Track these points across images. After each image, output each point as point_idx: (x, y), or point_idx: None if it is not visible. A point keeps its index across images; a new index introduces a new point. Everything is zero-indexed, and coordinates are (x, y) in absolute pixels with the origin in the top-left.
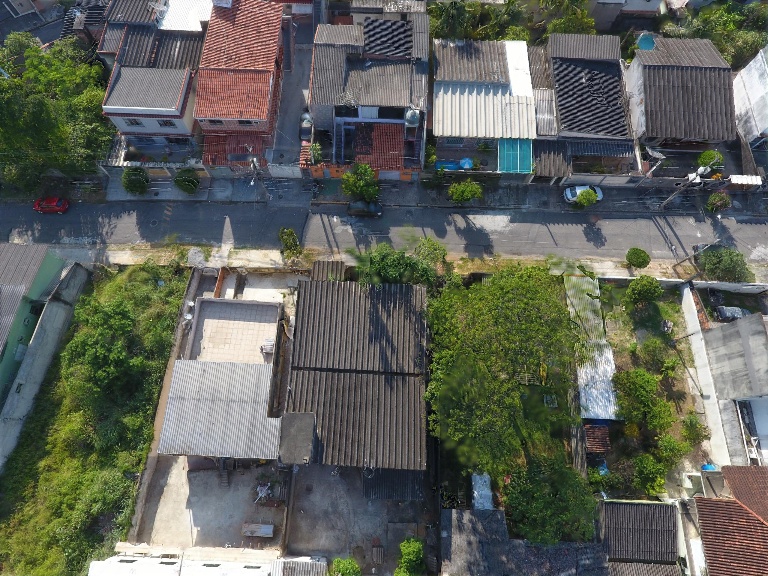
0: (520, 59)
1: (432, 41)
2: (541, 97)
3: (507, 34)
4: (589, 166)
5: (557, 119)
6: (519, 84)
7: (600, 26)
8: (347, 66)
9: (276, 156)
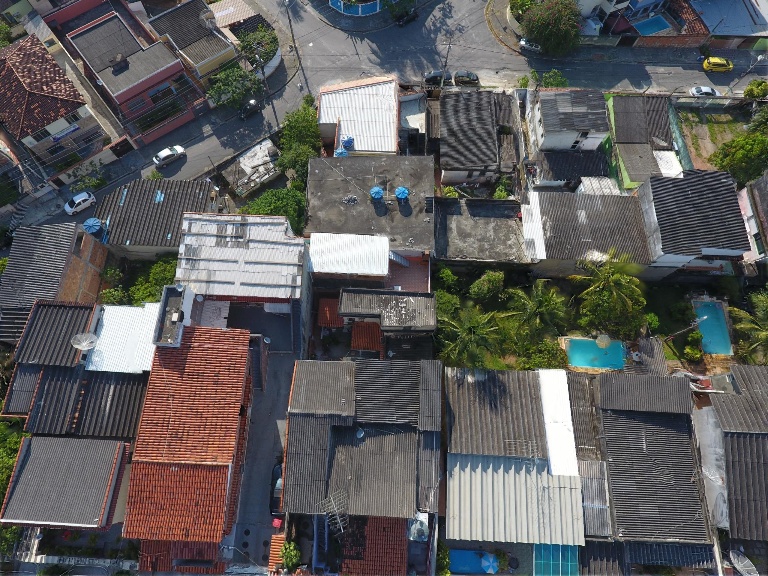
0: (559, 403)
1: (444, 374)
2: (589, 473)
3: (540, 350)
4: (653, 570)
5: (612, 516)
6: (559, 449)
7: (648, 278)
8: (332, 437)
9: (240, 532)
